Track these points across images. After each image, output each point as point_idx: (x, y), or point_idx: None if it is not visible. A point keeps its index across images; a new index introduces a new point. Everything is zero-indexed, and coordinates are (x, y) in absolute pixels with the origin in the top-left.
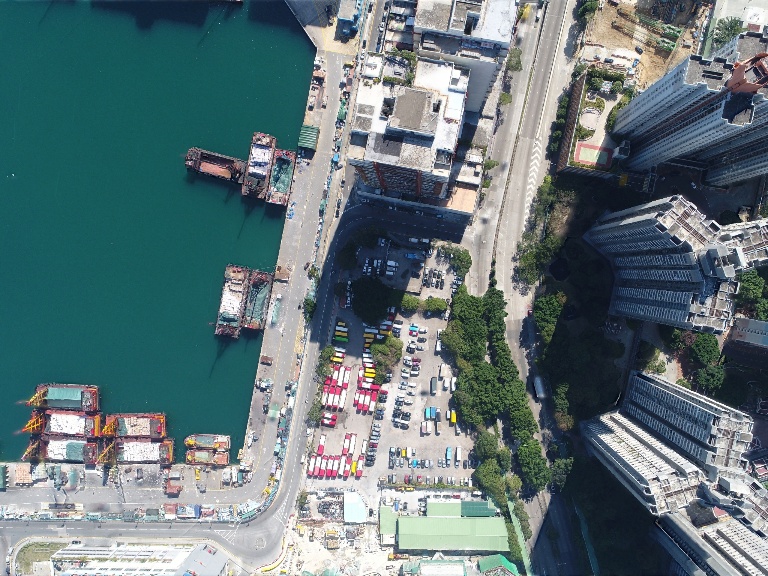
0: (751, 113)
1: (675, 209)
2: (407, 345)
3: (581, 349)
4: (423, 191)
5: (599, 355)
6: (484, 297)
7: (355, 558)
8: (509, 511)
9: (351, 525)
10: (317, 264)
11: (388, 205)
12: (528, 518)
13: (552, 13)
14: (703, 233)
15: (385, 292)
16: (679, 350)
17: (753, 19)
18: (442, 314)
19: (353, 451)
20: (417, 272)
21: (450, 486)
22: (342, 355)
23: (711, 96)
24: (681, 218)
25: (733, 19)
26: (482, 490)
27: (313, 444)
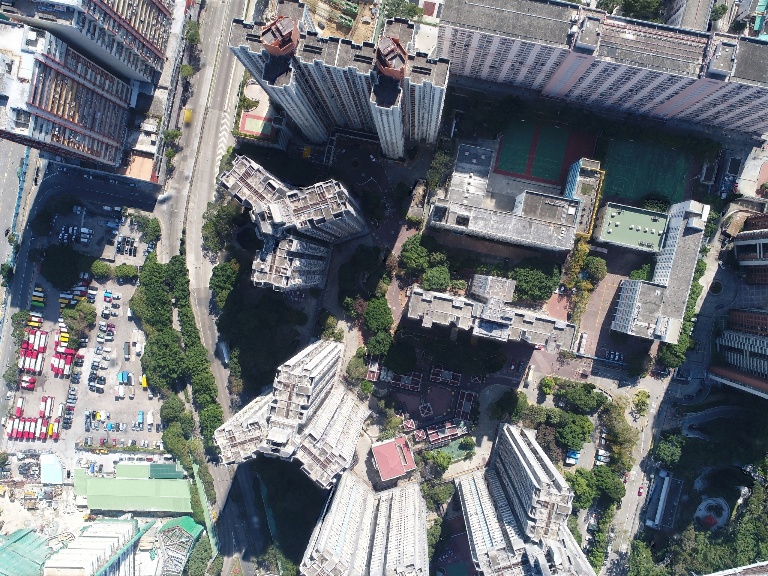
0: (291, 75)
1: (237, 169)
2: (101, 311)
3: (250, 315)
4: (78, 156)
5: (275, 321)
6: (167, 264)
7: (54, 519)
8: (194, 473)
9: (50, 486)
10: (16, 231)
11: (84, 174)
12: (212, 480)
13: None
14: (264, 192)
15: (74, 258)
16: (360, 319)
17: None
18: (133, 281)
19: (49, 414)
20: (111, 239)
21: (142, 449)
22: (38, 320)
23: (264, 59)
24: (242, 177)
25: None
26: (171, 453)
27: (14, 407)
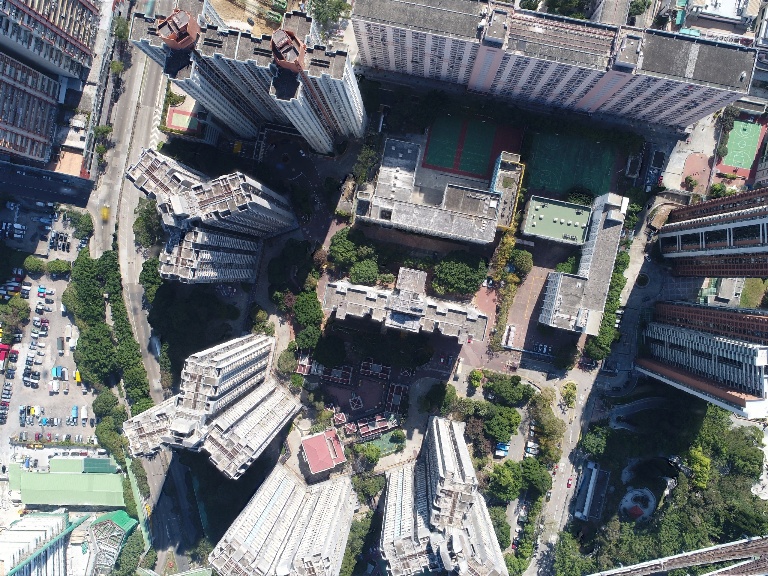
0: None
1: (143, 162)
2: (35, 306)
3: (178, 309)
4: (3, 152)
5: (205, 316)
6: (98, 259)
7: None
8: (126, 467)
9: None
10: None
11: (17, 170)
12: (145, 474)
13: None
14: (169, 185)
15: (6, 253)
16: (291, 313)
17: None
18: (66, 276)
19: None
20: (44, 235)
21: (76, 444)
22: None
23: (167, 53)
24: (148, 170)
25: None
26: None
27: None
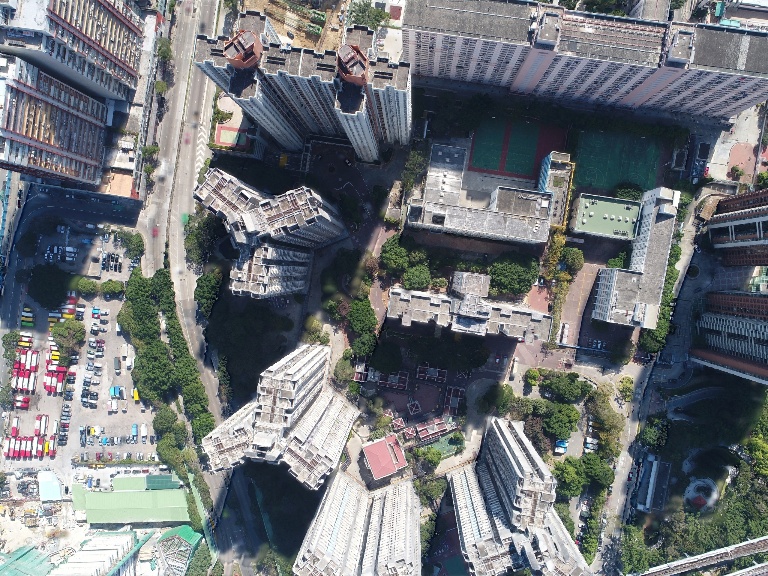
0: None
1: (210, 181)
2: (90, 327)
3: (235, 323)
4: (57, 177)
5: (260, 329)
6: (152, 278)
7: (54, 535)
8: (189, 483)
9: (49, 503)
10: (3, 253)
11: (65, 193)
12: (208, 489)
13: (205, 3)
14: (237, 203)
15: (60, 277)
16: (344, 321)
17: (395, 1)
18: (120, 296)
19: (44, 431)
20: (96, 257)
21: (138, 461)
22: (29, 339)
23: (230, 73)
24: (215, 189)
25: (367, 2)
26: (166, 464)
27: (9, 427)
